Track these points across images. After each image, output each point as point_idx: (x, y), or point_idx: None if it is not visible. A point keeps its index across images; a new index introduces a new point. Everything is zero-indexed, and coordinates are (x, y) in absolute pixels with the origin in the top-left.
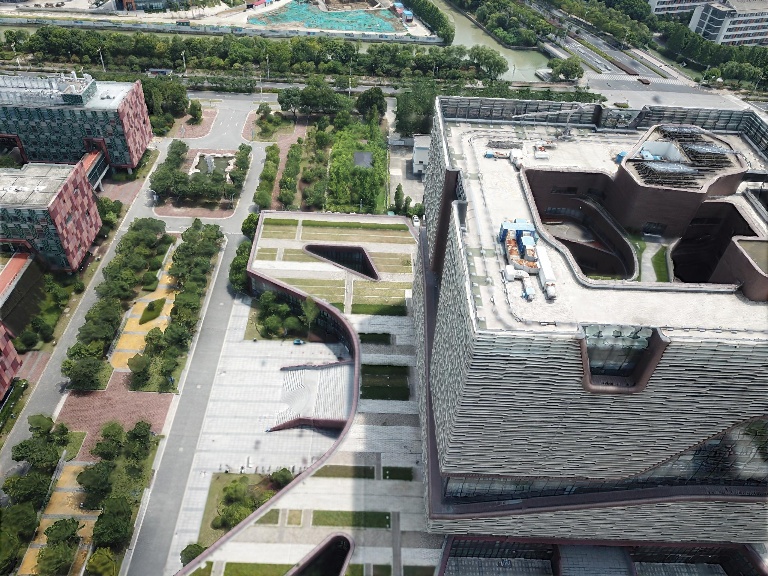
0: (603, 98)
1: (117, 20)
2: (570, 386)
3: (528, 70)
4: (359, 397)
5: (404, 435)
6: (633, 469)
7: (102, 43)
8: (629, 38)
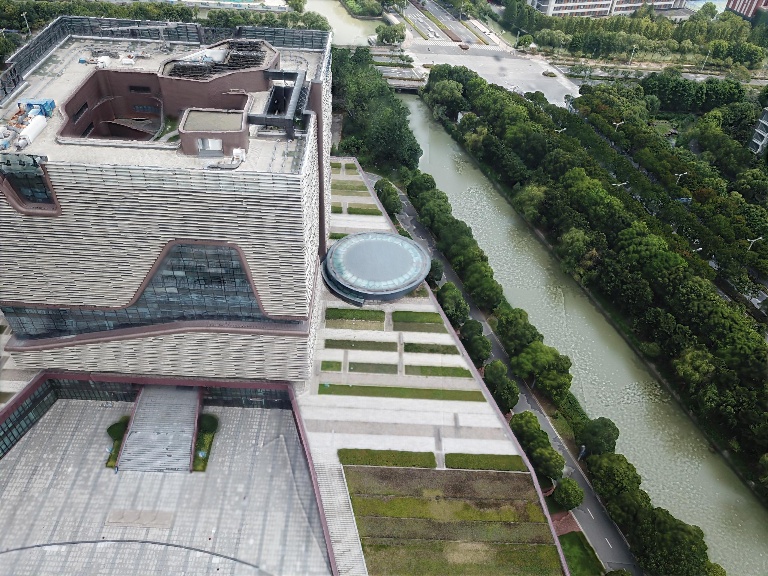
0: (409, 59)
1: None
2: (6, 208)
3: (363, 37)
4: None
5: None
6: (124, 297)
7: None
8: (466, 9)
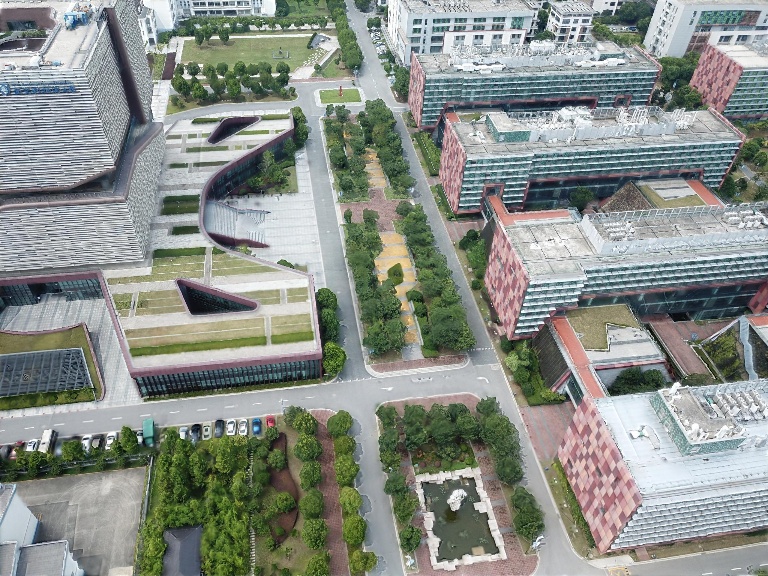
0: None
1: None
2: None
3: None
4: (201, 195)
5: (172, 181)
6: None
7: None
8: None
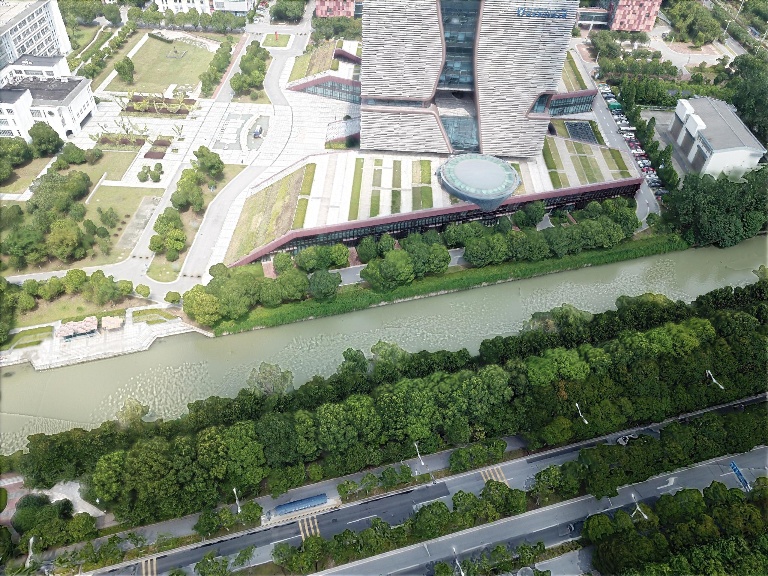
0: None
1: None
2: None
3: None
4: None
5: None
6: None
7: (760, 3)
8: None
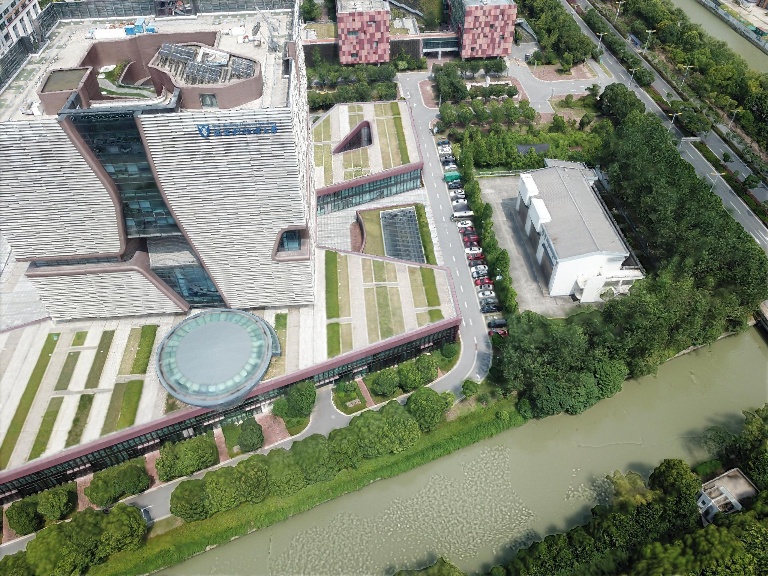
0: None
1: (728, 6)
2: None
3: None
4: None
5: None
6: None
7: (640, 3)
8: None
